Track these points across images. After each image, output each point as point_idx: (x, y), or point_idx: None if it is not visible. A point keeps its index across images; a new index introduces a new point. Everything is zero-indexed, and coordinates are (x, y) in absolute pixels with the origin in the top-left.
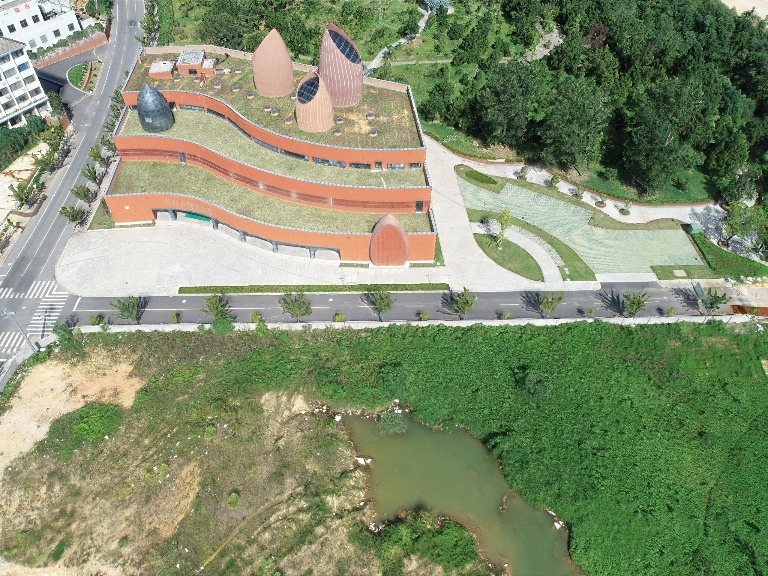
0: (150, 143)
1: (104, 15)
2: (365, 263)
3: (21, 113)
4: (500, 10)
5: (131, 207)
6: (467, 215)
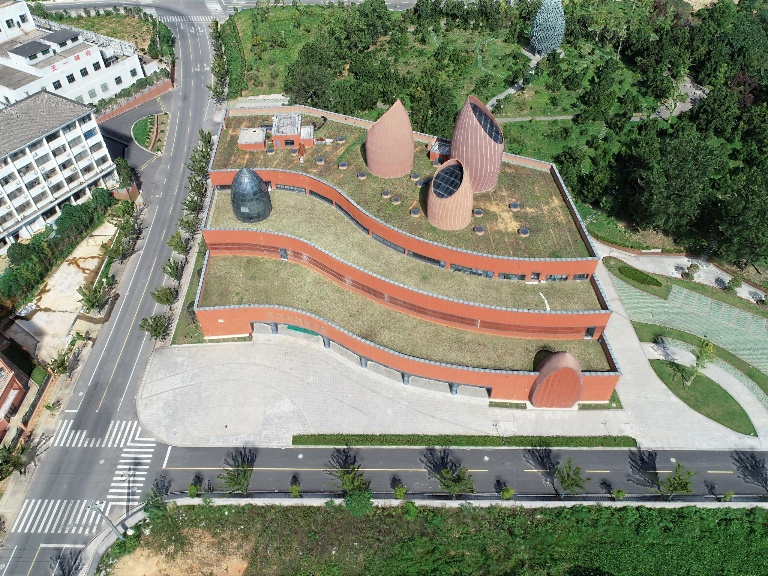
0: (246, 237)
1: (167, 56)
2: (521, 402)
3: (86, 186)
4: (615, 52)
5: (226, 320)
6: (634, 331)
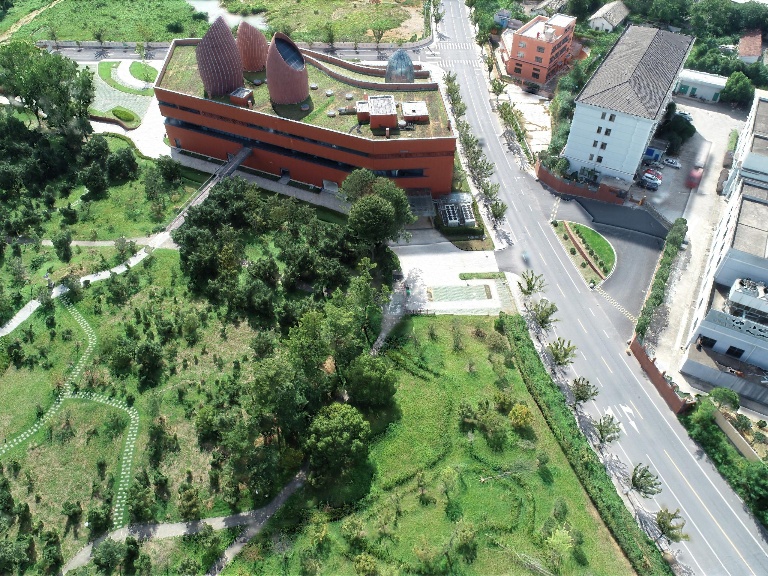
0: None
1: None
2: None
3: None
4: None
5: None
6: None
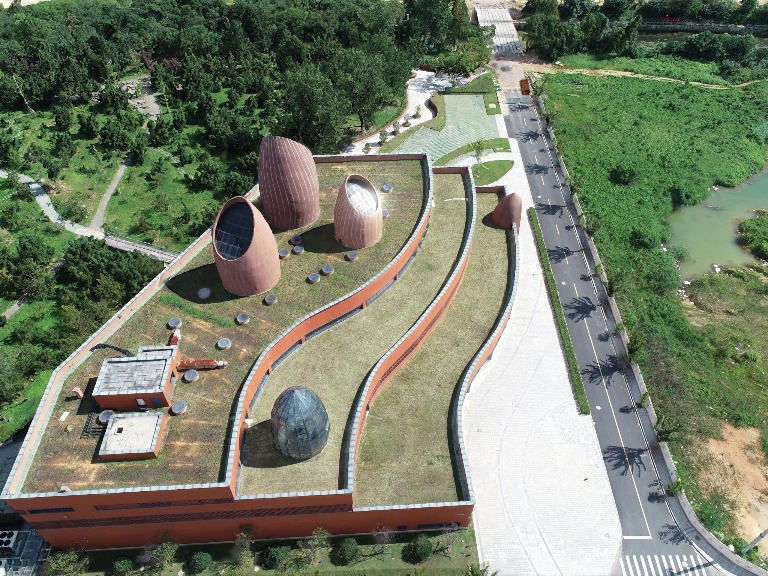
0: None
1: None
2: None
3: None
4: None
5: None
6: None
